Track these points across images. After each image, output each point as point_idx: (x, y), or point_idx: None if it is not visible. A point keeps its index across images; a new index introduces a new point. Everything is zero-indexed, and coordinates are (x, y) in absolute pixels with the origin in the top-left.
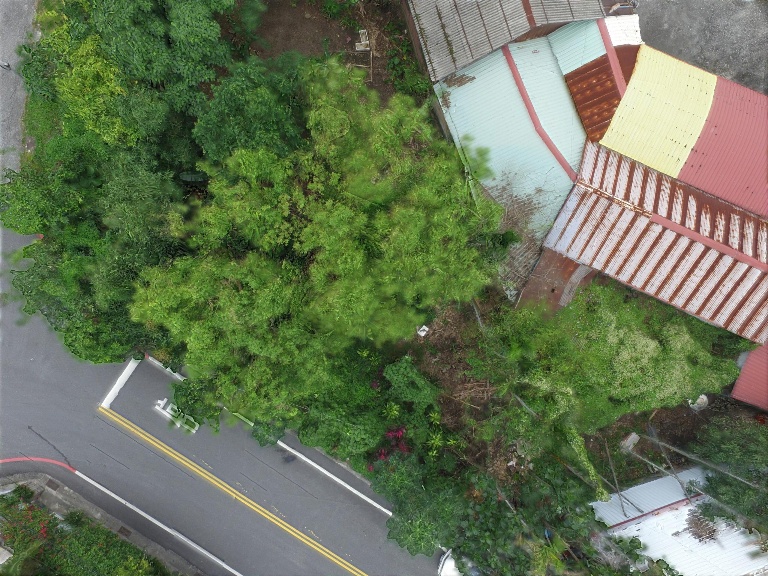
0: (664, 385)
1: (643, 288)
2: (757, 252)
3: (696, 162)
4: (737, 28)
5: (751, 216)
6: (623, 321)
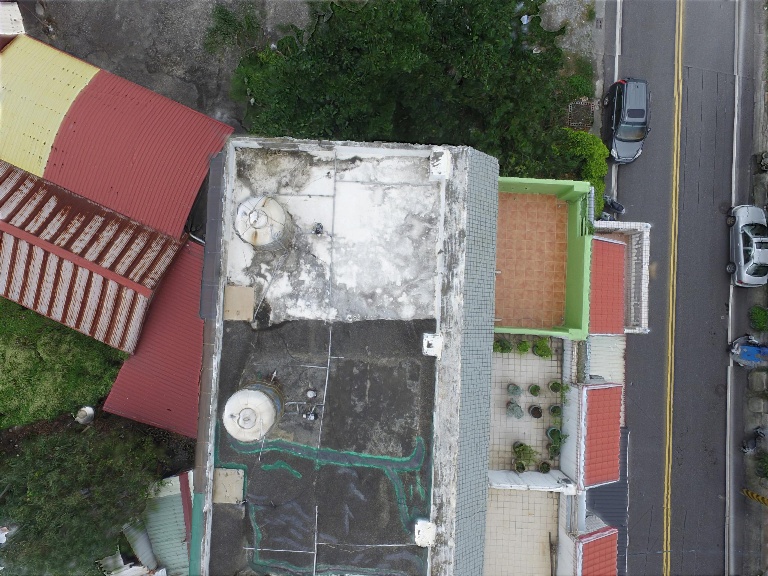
0: (35, 398)
1: (6, 295)
2: (105, 256)
3: (58, 160)
4: (191, 20)
5: (120, 218)
6: (5, 330)
